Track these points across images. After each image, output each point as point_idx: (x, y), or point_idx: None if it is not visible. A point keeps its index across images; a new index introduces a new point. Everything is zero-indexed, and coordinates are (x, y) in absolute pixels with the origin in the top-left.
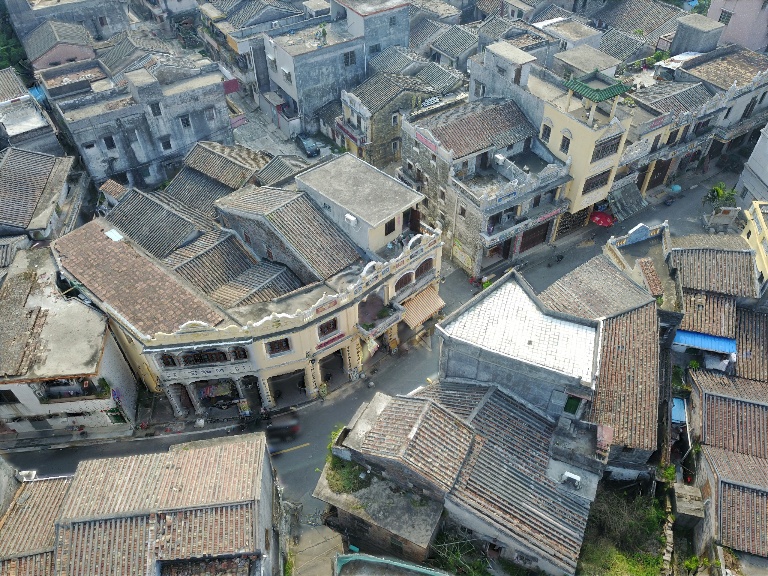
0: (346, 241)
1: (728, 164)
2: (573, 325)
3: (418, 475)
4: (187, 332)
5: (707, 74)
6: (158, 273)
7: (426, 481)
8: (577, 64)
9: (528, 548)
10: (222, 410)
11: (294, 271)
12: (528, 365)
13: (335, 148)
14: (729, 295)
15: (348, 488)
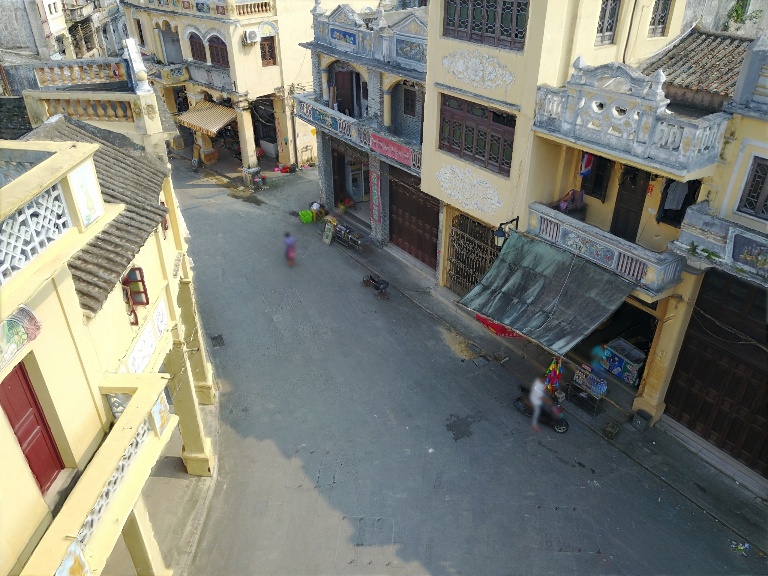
0: None
1: None
2: None
3: None
4: None
5: None
6: None
7: None
8: None
9: None
10: None
11: None
12: None
13: None
14: None
15: None
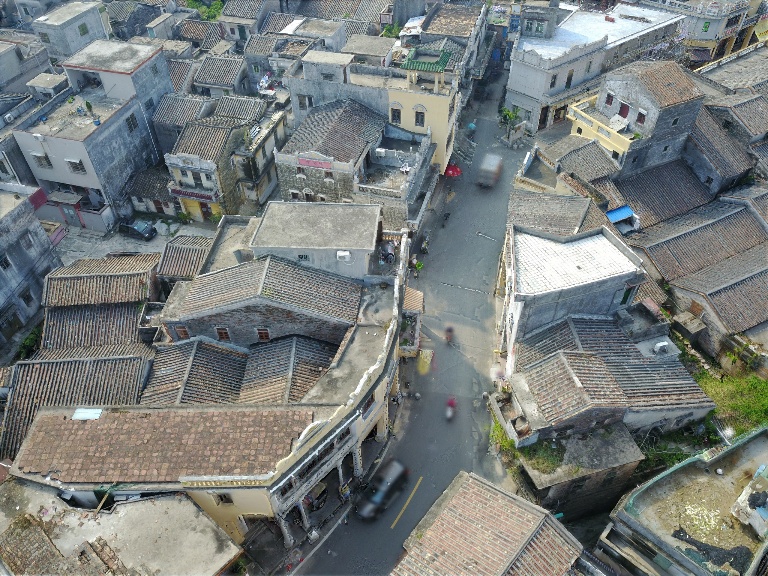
0: (340, 280)
1: (483, 95)
2: (587, 240)
3: (605, 409)
4: (305, 442)
5: (441, 30)
6: (192, 416)
7: (611, 410)
8: (367, 52)
9: (688, 408)
10: (320, 510)
11: (307, 335)
12: (599, 282)
13: (166, 219)
14: (605, 177)
15: (556, 462)
